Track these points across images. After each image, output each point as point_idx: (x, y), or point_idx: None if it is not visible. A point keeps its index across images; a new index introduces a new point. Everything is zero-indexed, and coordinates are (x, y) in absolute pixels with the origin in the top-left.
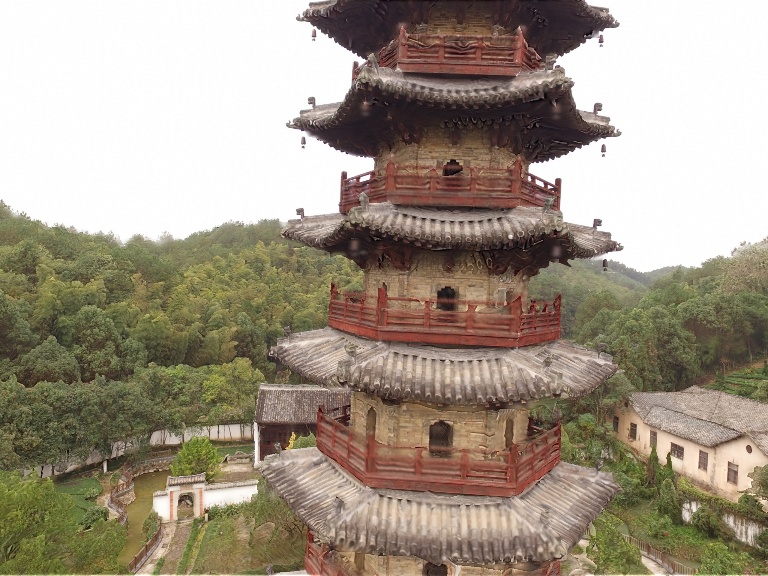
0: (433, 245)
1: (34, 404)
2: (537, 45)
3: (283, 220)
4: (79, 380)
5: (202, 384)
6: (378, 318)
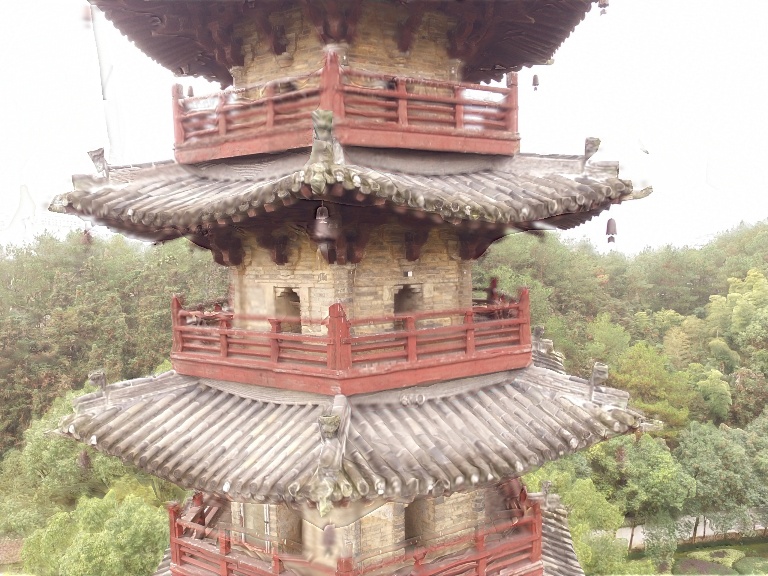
0: None
1: None
2: (326, 23)
3: None
4: None
5: None
6: None
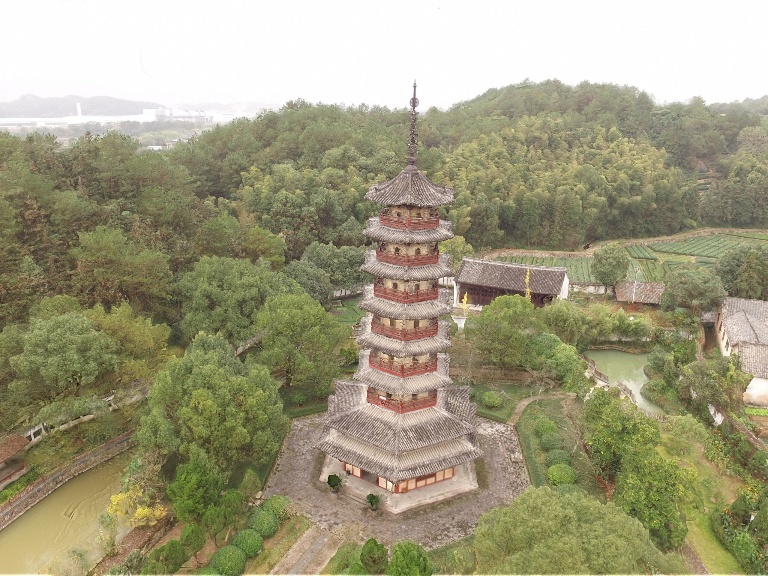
0: (380, 277)
1: (340, 258)
2: None
3: (566, 79)
4: (363, 245)
5: None
6: (374, 290)
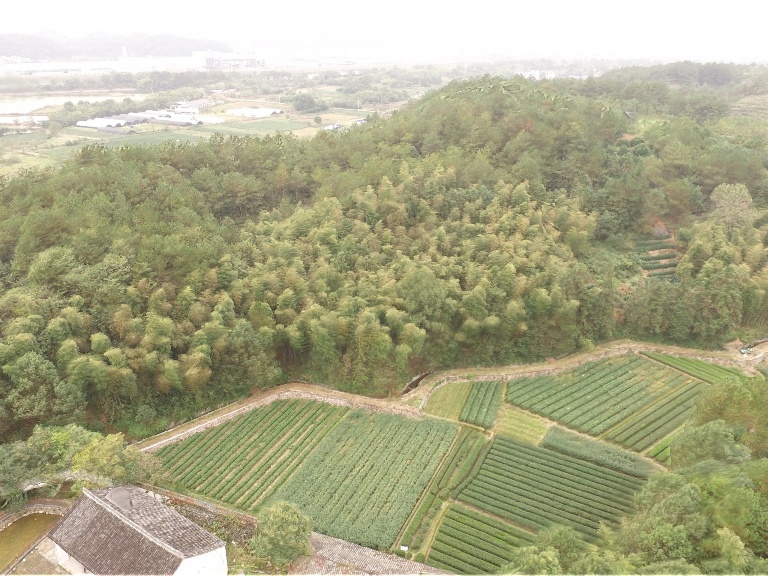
0: None
1: None
2: None
3: (520, 84)
4: None
5: (74, 456)
6: None
